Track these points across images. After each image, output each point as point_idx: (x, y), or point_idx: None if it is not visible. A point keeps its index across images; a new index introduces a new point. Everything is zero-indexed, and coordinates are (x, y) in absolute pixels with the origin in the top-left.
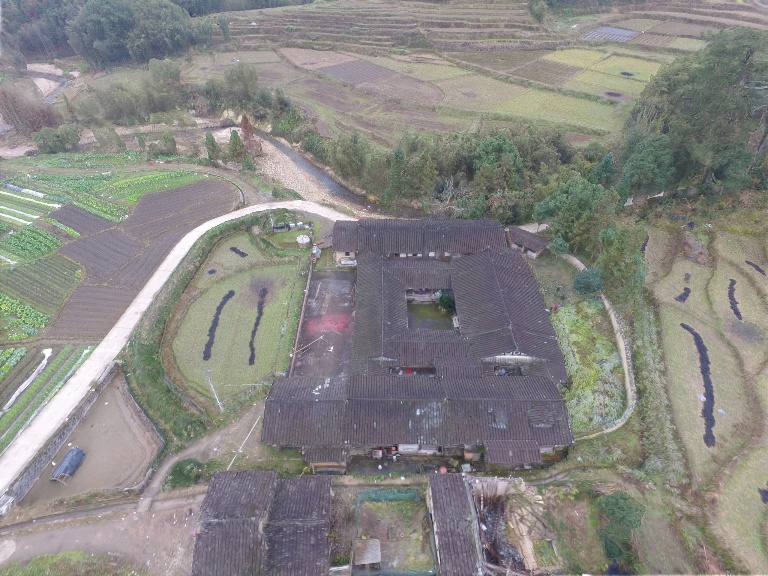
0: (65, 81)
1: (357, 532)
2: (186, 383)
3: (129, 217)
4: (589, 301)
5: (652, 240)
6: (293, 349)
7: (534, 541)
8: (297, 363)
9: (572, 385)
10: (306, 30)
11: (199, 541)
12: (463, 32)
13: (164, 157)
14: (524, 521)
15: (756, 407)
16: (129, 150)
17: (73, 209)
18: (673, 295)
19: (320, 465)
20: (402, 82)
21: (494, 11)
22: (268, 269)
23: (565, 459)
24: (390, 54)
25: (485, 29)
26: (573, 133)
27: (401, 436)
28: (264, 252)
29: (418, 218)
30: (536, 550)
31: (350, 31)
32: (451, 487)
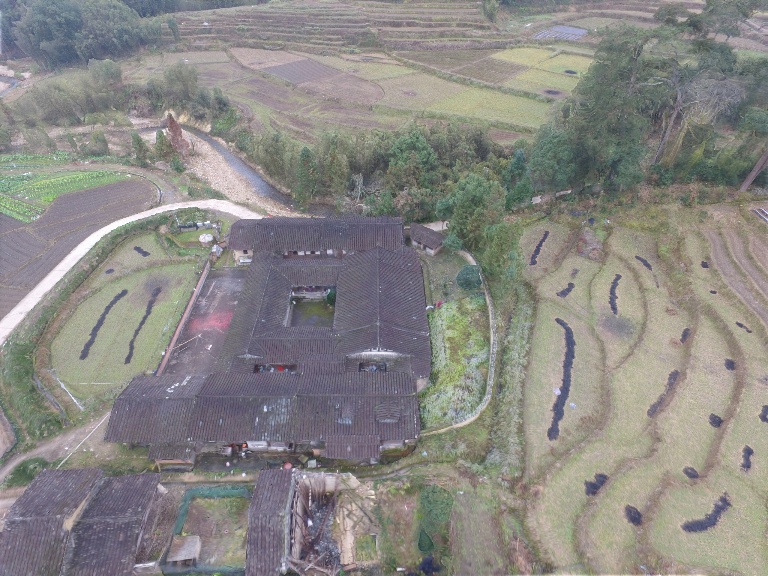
0: (15, 82)
1: (181, 529)
2: (55, 382)
3: (40, 217)
4: (471, 297)
5: (551, 236)
6: (167, 347)
7: (357, 536)
8: (172, 361)
9: (437, 381)
10: (258, 30)
11: (0, 539)
12: (414, 31)
13: (94, 157)
14: (351, 516)
15: (607, 400)
16: (59, 150)
17: None
18: (556, 290)
19: (166, 463)
20: (345, 81)
21: (447, 10)
22: (167, 268)
23: (410, 454)
24: (339, 53)
25: (437, 28)
26: (505, 131)
27: (245, 433)
28: (167, 251)
29: None
30: (358, 545)
31: (301, 31)
32: (276, 483)
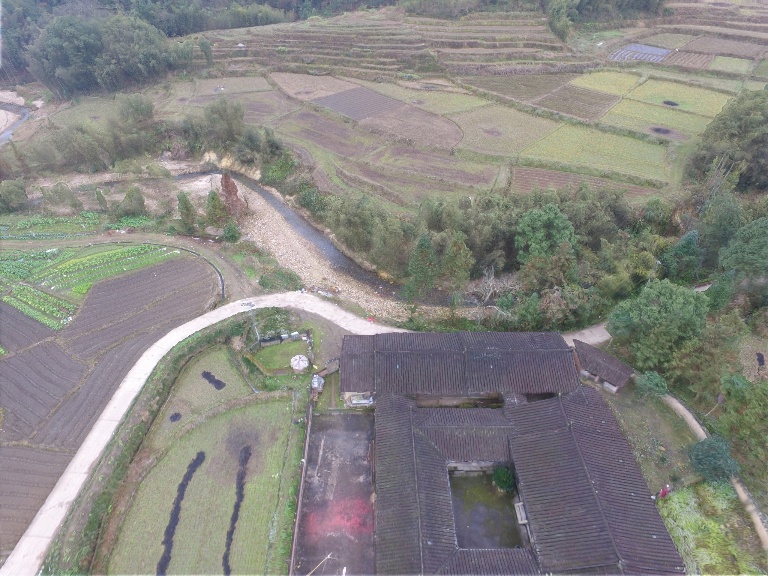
0: (26, 112)
1: None
2: None
3: (73, 320)
4: (713, 485)
5: None
6: None
7: None
8: None
9: None
10: (300, 52)
11: None
12: (478, 53)
13: (129, 220)
14: None
15: None
16: (86, 211)
17: (1, 308)
18: None
19: None
20: (412, 116)
21: (511, 28)
22: (252, 410)
23: None
24: (396, 80)
25: (502, 49)
26: (623, 184)
27: None
28: (247, 379)
29: (444, 305)
30: None
31: (350, 53)
32: None
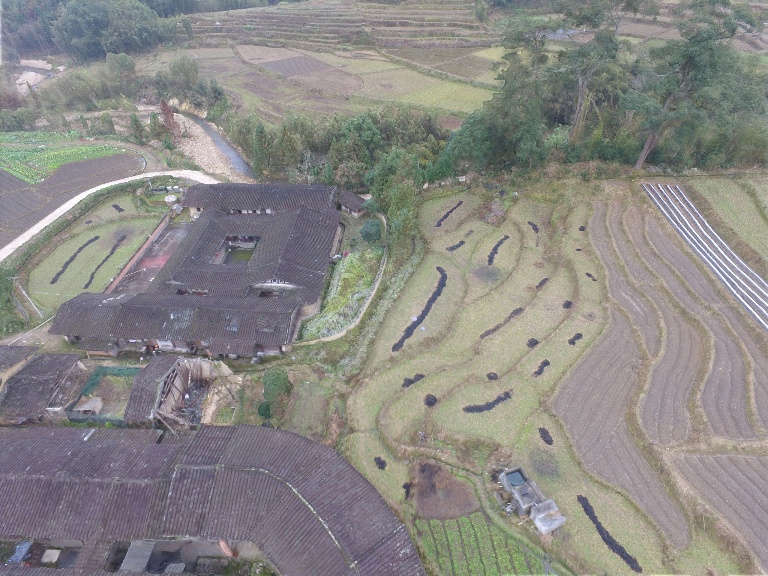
0: (51, 74)
1: None
2: (27, 298)
3: (44, 180)
4: (372, 248)
5: (464, 205)
6: (116, 276)
7: (220, 407)
8: (119, 288)
9: (324, 309)
10: (263, 29)
11: None
12: (405, 30)
13: (101, 136)
14: (219, 394)
15: (451, 326)
16: (73, 130)
17: (2, 173)
18: (446, 246)
19: (94, 354)
20: (332, 75)
21: (441, 11)
22: (135, 221)
23: (281, 358)
24: (334, 50)
25: (428, 28)
26: None
27: (154, 333)
28: (139, 209)
29: None
30: (220, 413)
31: (302, 30)
32: (163, 363)
